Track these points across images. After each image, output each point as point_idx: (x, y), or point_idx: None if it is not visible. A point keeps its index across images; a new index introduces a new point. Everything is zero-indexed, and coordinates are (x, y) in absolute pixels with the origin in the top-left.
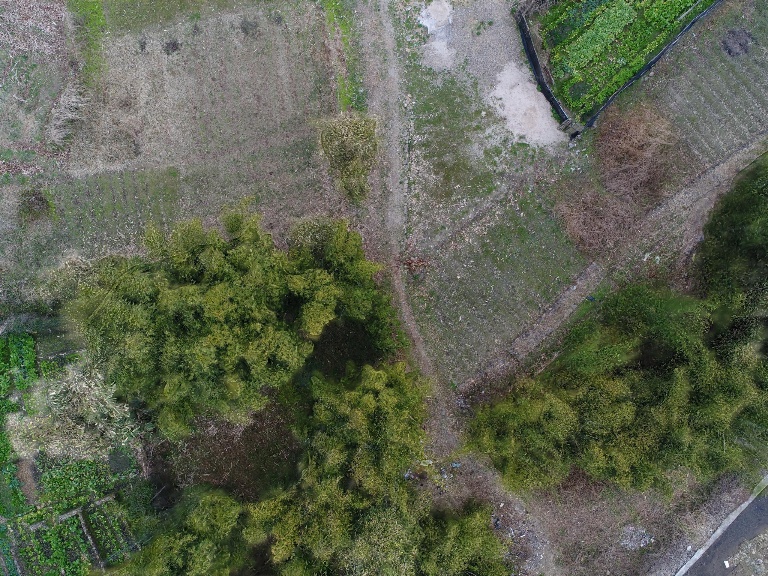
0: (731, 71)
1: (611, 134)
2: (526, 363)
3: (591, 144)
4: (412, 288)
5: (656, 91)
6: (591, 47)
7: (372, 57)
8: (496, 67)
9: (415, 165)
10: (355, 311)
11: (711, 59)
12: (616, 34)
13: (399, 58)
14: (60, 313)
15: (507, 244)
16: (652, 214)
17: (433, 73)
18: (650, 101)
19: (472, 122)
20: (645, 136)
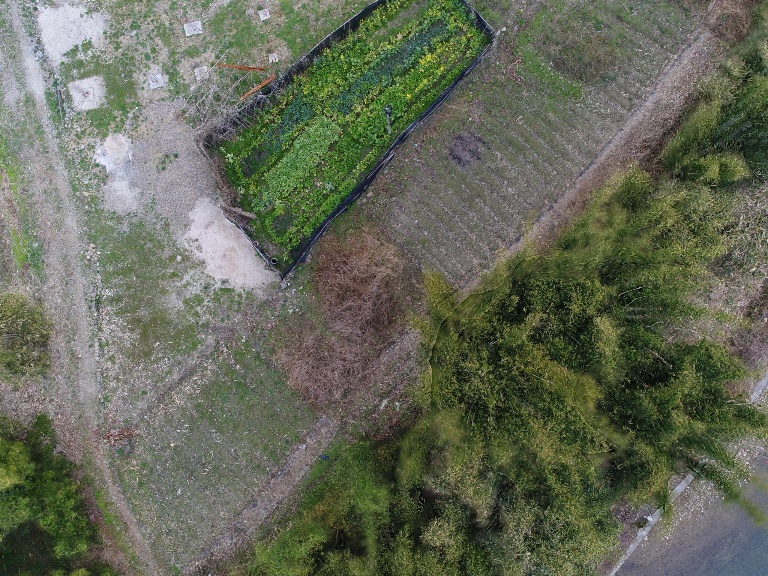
0: (463, 182)
1: (329, 268)
2: (257, 537)
3: (308, 281)
4: (119, 462)
5: (378, 213)
6: (292, 173)
7: (45, 206)
8: (186, 205)
9: (107, 324)
10: (8, 522)
11: (438, 171)
12: (321, 155)
13: (76, 204)
14: None
15: (224, 402)
16: (385, 355)
17: (118, 217)
18: (372, 225)
19: (167, 269)
20: (370, 266)
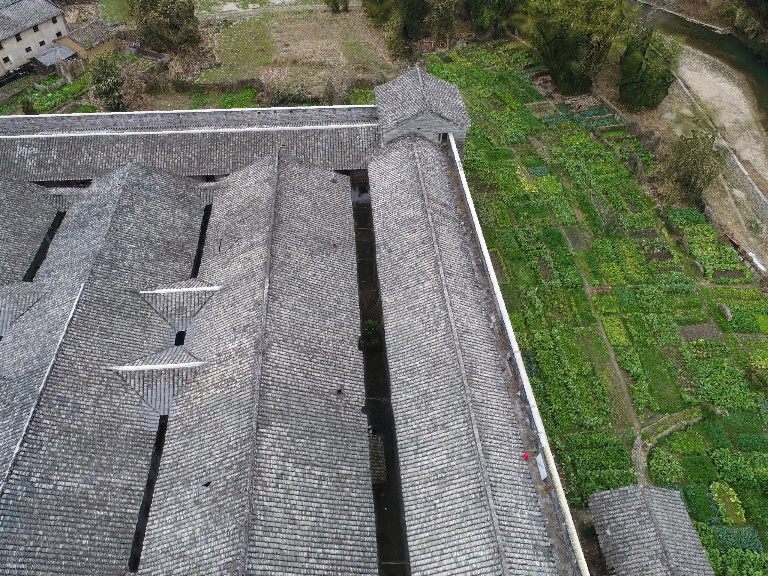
0: None
1: None
2: None
3: None
4: None
5: None
6: None
7: None
8: None
9: None
10: None
11: None
12: None
13: None
14: (411, 61)
15: None
16: None
17: (297, 2)
18: None
19: None
20: None
